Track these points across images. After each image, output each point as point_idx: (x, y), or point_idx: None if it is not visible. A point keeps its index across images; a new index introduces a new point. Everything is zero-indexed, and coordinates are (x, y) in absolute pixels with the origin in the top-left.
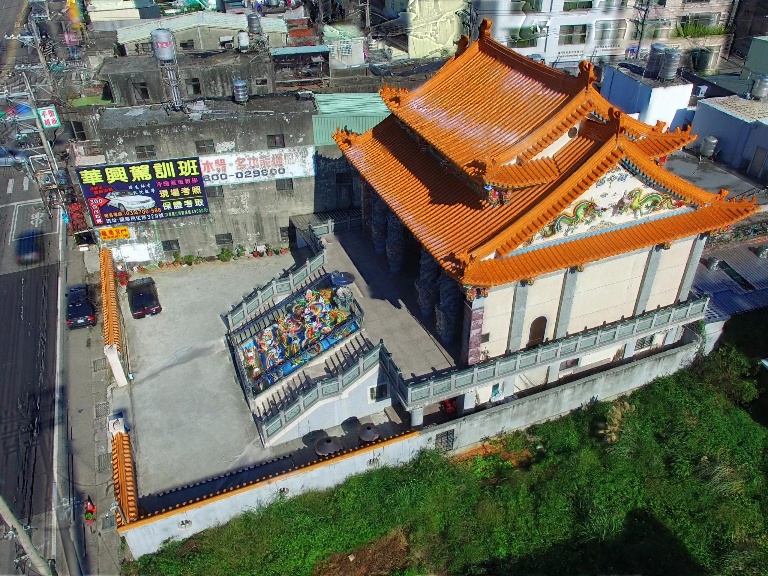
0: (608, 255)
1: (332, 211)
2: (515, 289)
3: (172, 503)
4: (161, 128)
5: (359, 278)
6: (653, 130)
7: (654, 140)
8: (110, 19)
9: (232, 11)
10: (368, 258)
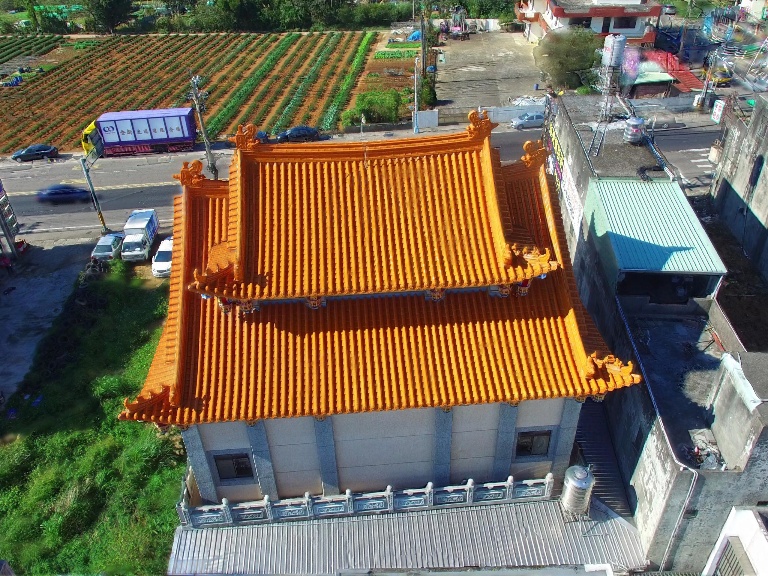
0: None
1: None
2: None
3: None
4: None
5: None
6: (234, 262)
7: None
8: None
9: None
10: None
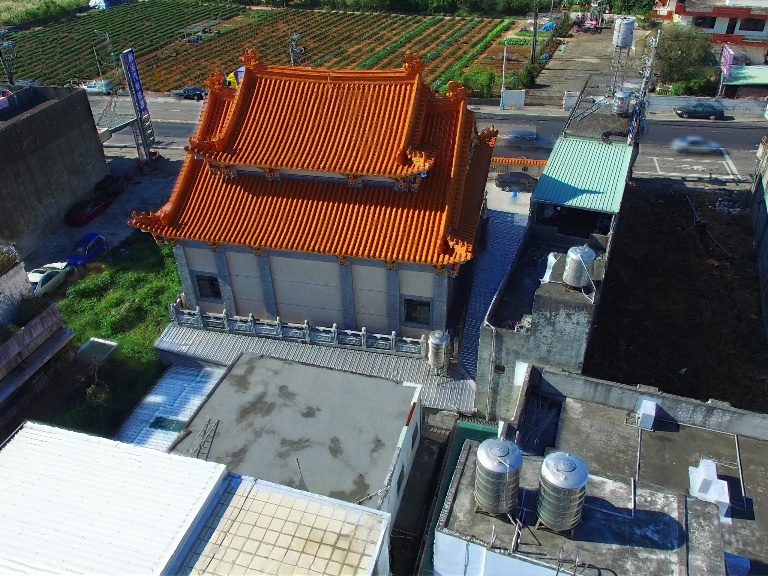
0: None
1: None
2: None
3: None
4: None
5: None
6: None
7: None
8: None
9: None
10: None
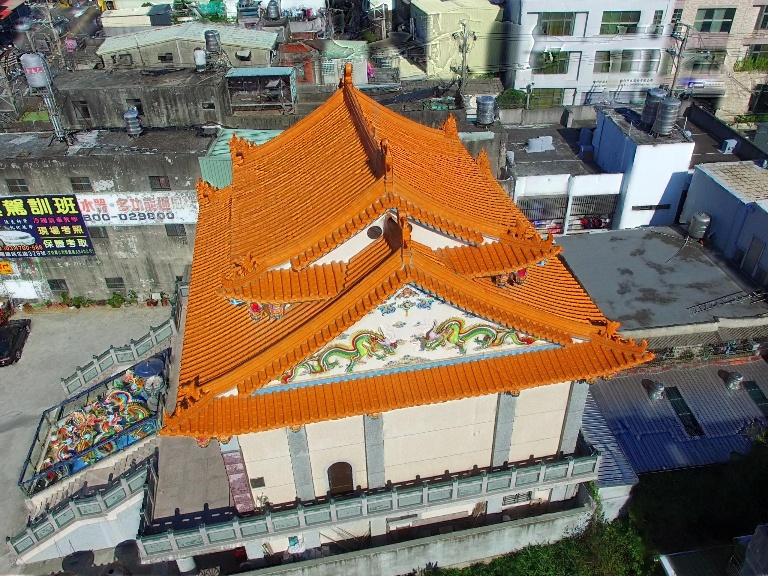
0: (402, 406)
1: None
2: (286, 430)
3: None
4: (30, 161)
5: None
6: (508, 233)
7: (508, 246)
8: (122, 25)
9: (243, 21)
10: None
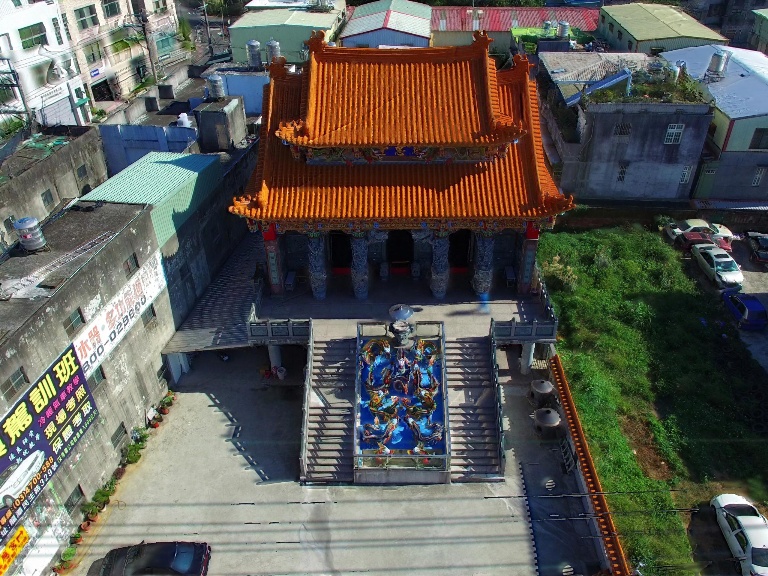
0: None
1: (188, 316)
2: None
3: None
4: (24, 332)
5: (356, 322)
6: None
7: None
8: None
9: None
10: (325, 308)
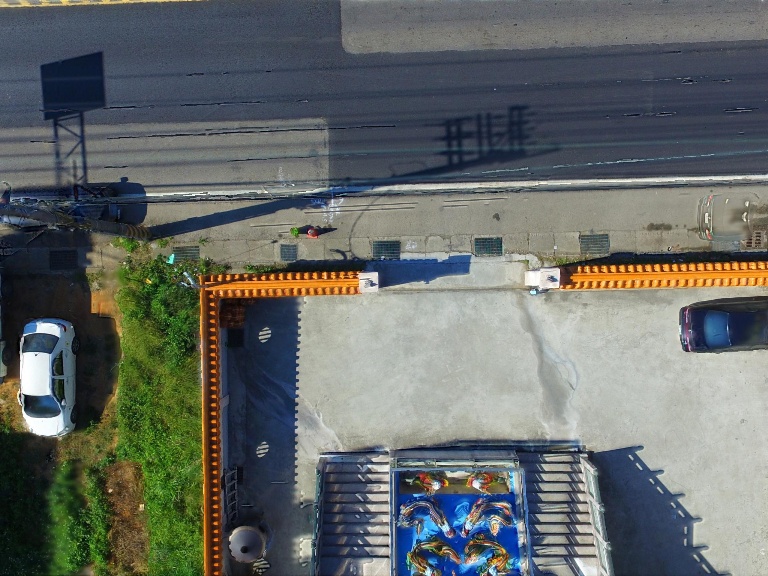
0: None
1: None
2: None
3: (282, 327)
4: None
5: None
6: None
7: None
8: None
9: None
10: None
